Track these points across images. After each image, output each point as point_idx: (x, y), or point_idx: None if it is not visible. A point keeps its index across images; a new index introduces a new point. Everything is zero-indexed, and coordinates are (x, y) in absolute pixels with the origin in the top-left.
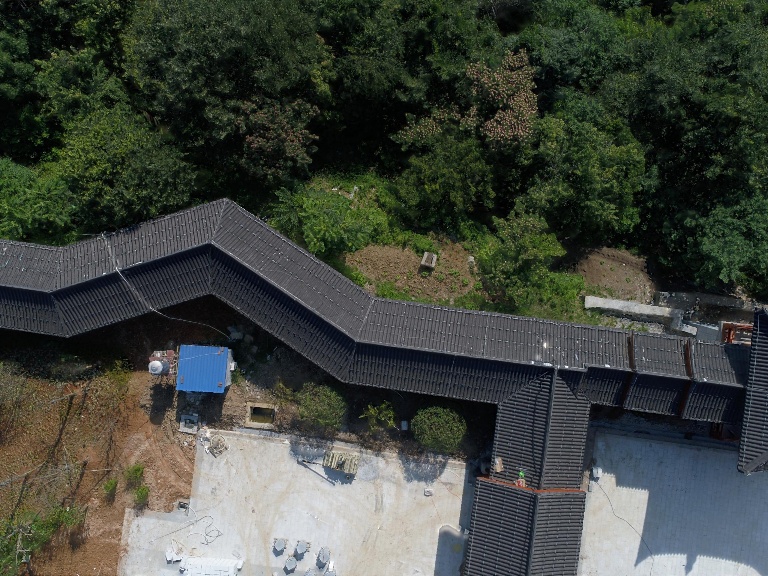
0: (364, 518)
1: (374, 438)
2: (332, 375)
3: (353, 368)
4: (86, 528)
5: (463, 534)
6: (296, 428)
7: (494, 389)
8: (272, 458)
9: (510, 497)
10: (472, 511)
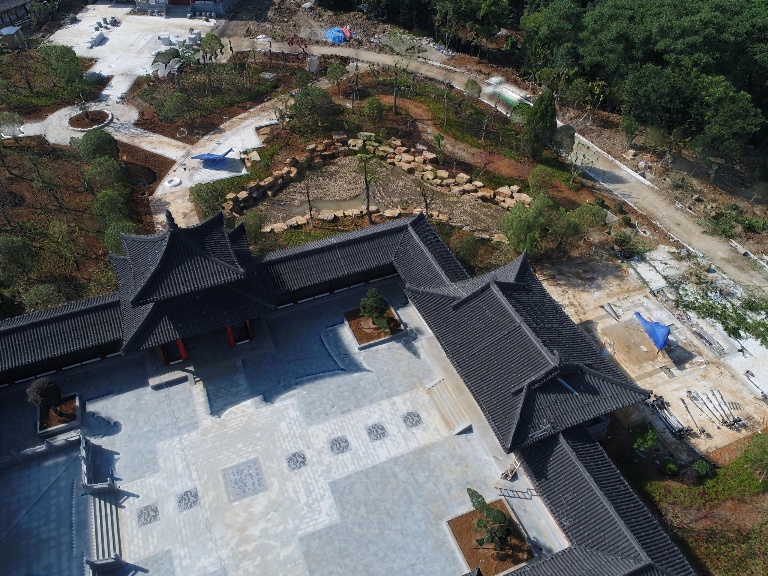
0: (97, 18)
1: None
2: (26, 3)
3: None
4: None
5: (113, 4)
6: (52, 28)
7: None
8: None
9: None
10: None
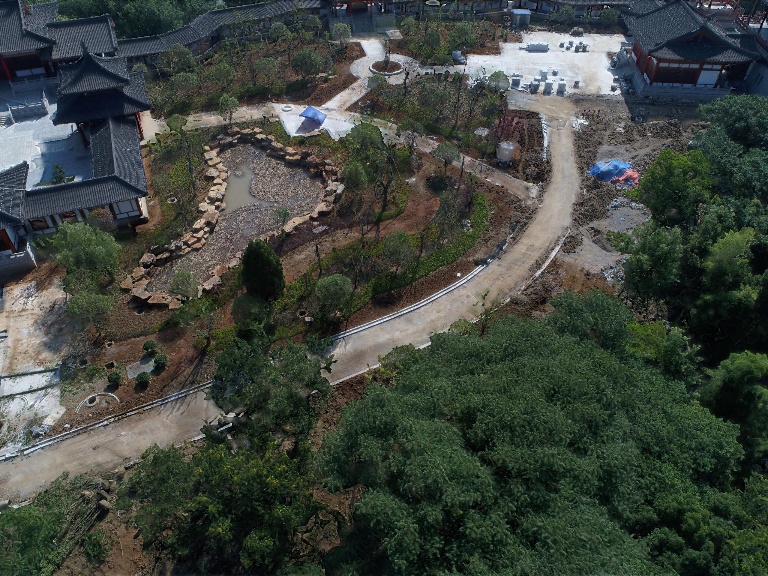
0: None
1: (586, 30)
2: None
3: (576, 0)
4: (486, 44)
5: (630, 43)
6: (556, 29)
7: (624, 0)
8: (550, 34)
9: (642, 1)
10: (631, 8)
